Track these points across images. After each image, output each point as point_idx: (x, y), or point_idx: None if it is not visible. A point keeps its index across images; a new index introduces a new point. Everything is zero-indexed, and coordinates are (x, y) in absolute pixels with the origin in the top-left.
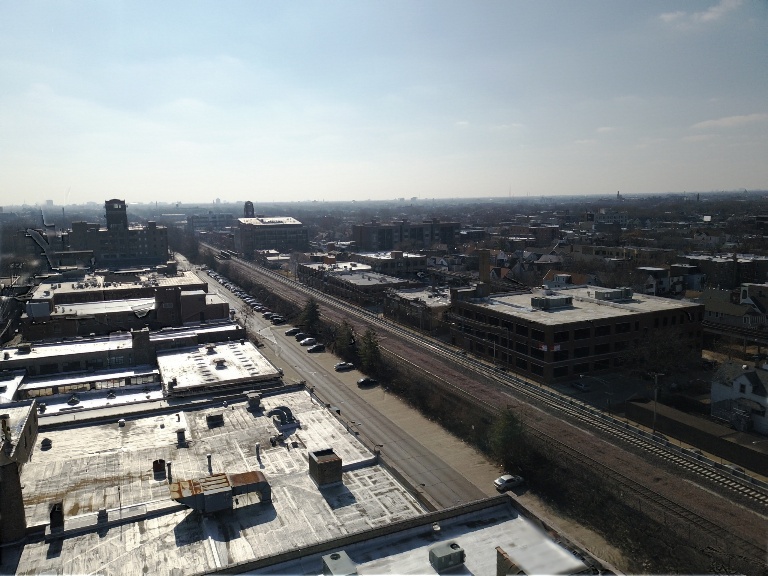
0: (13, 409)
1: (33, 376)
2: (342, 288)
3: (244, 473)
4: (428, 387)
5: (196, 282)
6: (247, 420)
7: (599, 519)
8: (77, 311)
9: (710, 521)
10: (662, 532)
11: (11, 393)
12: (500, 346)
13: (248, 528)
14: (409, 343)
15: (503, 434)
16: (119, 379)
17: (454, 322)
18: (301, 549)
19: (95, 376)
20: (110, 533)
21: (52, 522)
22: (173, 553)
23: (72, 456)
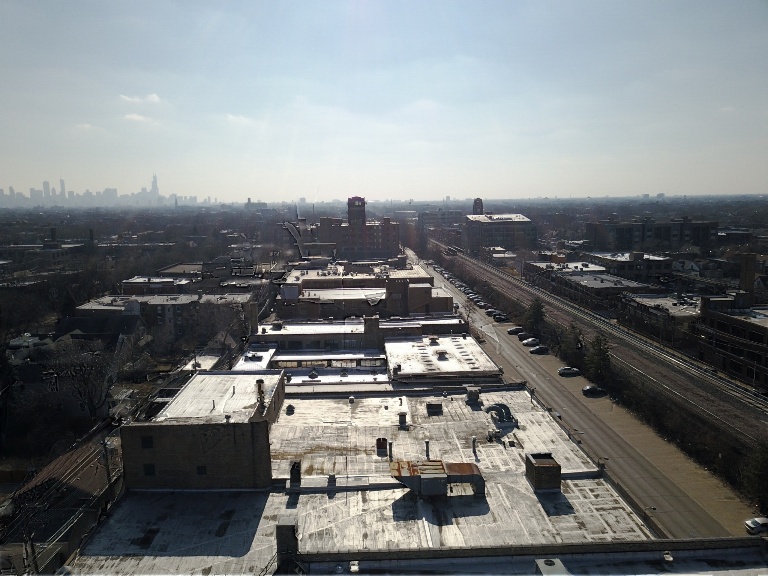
0: (267, 376)
1: (283, 350)
2: (571, 289)
3: (460, 463)
4: (666, 404)
5: (423, 275)
6: (465, 412)
7: None
8: (320, 296)
9: None
10: None
11: (265, 363)
12: (763, 367)
13: (461, 517)
14: (645, 353)
15: (761, 469)
16: (351, 360)
17: (703, 335)
18: (513, 547)
19: (331, 355)
20: (337, 497)
21: (292, 477)
22: (390, 526)
23: (310, 423)
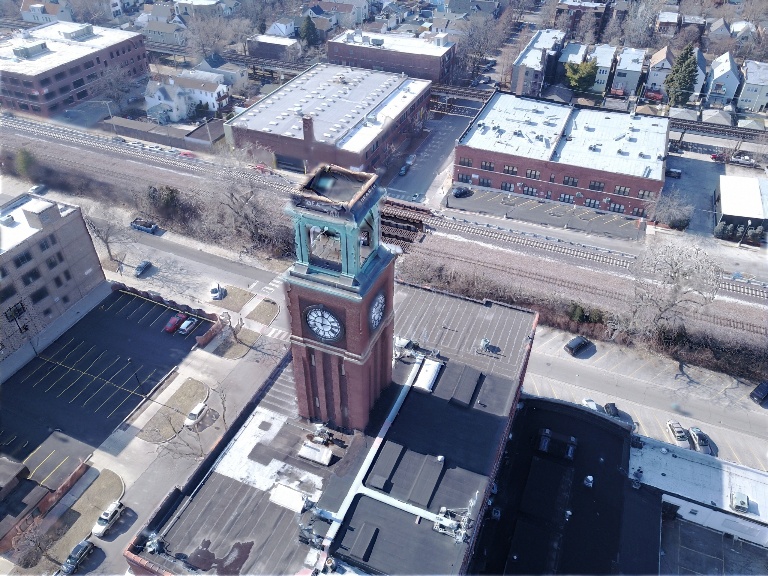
0: None
1: None
2: None
3: None
4: None
5: None
6: None
7: (88, 192)
8: None
9: (135, 176)
10: (115, 188)
11: None
12: (3, 96)
13: None
14: None
15: (24, 164)
16: None
17: None
18: None
19: None
20: None
21: None
22: None
23: None
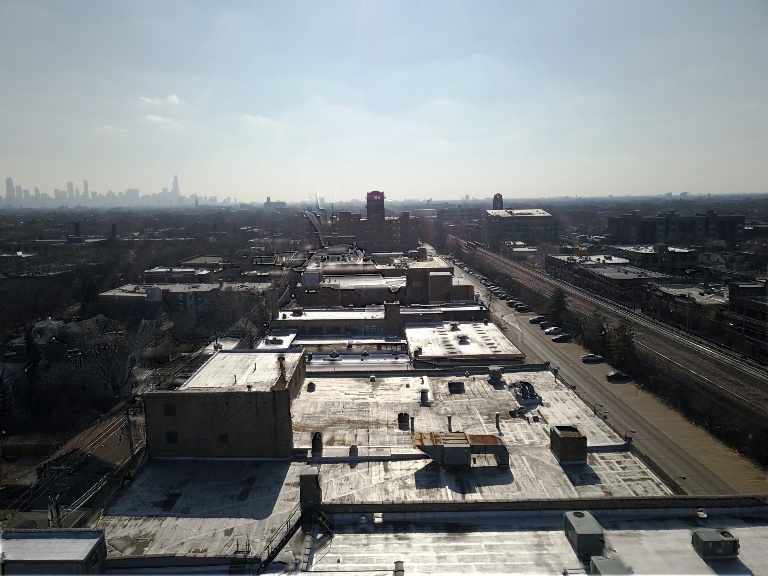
0: (287, 354)
1: (303, 335)
2: (593, 281)
3: None
4: (693, 388)
5: (443, 266)
6: (487, 391)
7: None
8: (340, 282)
9: None
10: None
11: (286, 346)
12: None
13: (484, 486)
14: (671, 340)
15: None
16: (371, 344)
17: (731, 322)
18: (541, 501)
19: None
20: (359, 466)
21: (313, 447)
22: (412, 493)
23: (330, 399)
